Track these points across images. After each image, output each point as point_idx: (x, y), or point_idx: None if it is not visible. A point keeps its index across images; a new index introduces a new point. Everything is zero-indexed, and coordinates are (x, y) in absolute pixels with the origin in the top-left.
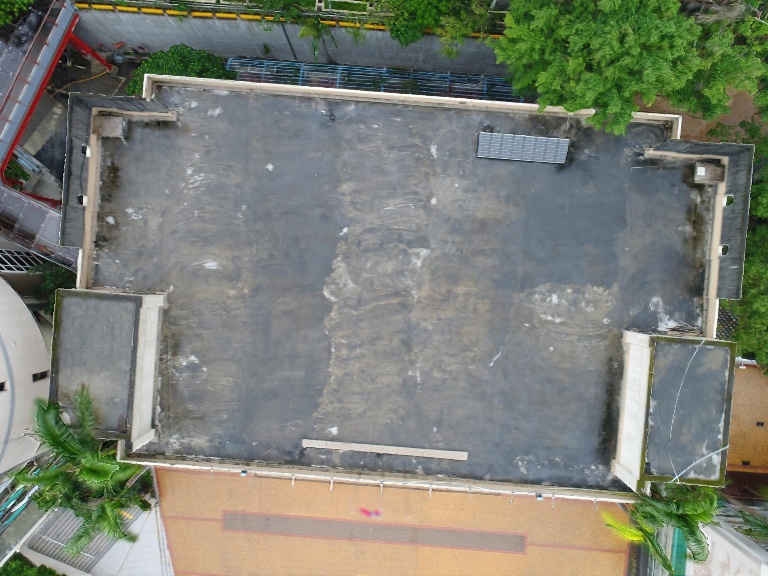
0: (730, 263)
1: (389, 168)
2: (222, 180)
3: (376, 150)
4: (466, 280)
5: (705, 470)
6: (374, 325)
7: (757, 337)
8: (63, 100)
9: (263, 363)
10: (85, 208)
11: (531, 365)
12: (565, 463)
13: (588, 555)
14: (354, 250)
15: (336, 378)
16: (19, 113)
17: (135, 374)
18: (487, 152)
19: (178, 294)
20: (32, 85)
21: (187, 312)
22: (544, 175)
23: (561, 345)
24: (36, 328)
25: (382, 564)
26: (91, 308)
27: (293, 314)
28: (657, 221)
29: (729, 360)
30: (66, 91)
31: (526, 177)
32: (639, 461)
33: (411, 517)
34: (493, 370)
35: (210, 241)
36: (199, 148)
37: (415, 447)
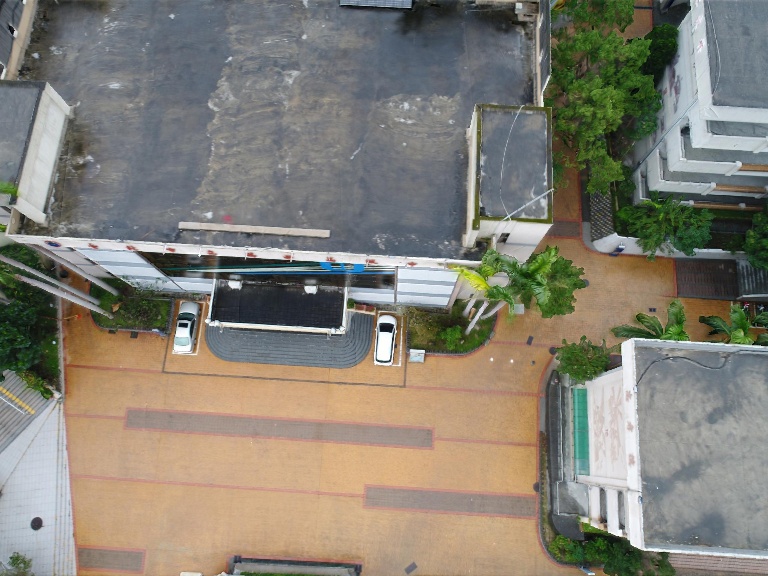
0: (544, 58)
1: (269, 15)
2: (132, 26)
3: (259, 3)
4: (330, 93)
5: (535, 212)
6: (250, 129)
7: (596, 154)
8: None
9: (150, 160)
10: (14, 39)
11: (387, 158)
12: (420, 239)
13: (498, 449)
14: (236, 73)
15: (214, 171)
16: None
17: (30, 141)
18: (347, 0)
19: (83, 108)
20: None
21: (89, 122)
22: (395, 18)
23: (413, 141)
24: None
25: (285, 463)
26: (1, 93)
27: (180, 121)
28: (490, 48)
29: (546, 121)
30: None
31: (380, 19)
32: (473, 204)
33: (316, 412)
34: (353, 162)
35: (116, 68)
36: (116, 5)
37: (282, 227)
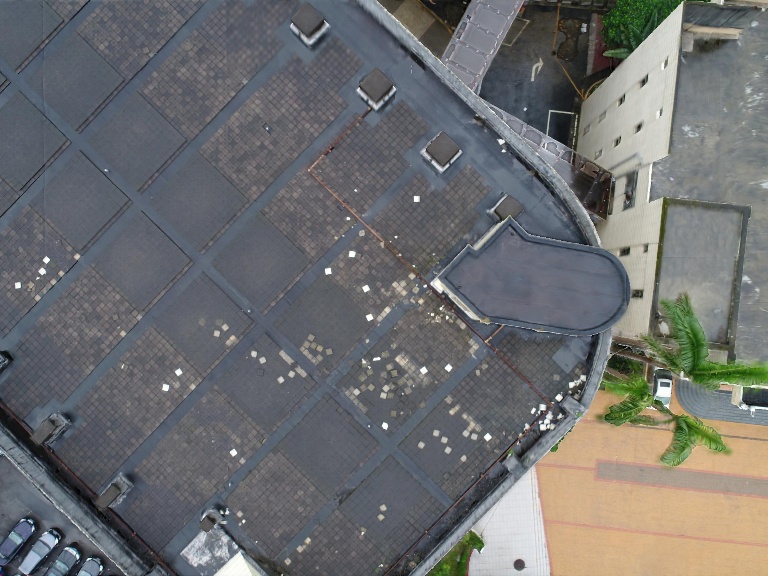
0: None
1: None
2: None
3: None
4: None
5: None
6: None
7: None
8: None
9: None
10: None
11: None
12: None
13: None
14: None
15: None
16: None
17: (741, 285)
18: None
19: None
20: None
21: None
22: None
23: None
24: None
25: (756, 519)
26: (696, 217)
27: None
28: None
29: None
30: None
31: None
32: None
33: None
34: None
35: (767, 161)
36: (759, 67)
37: None
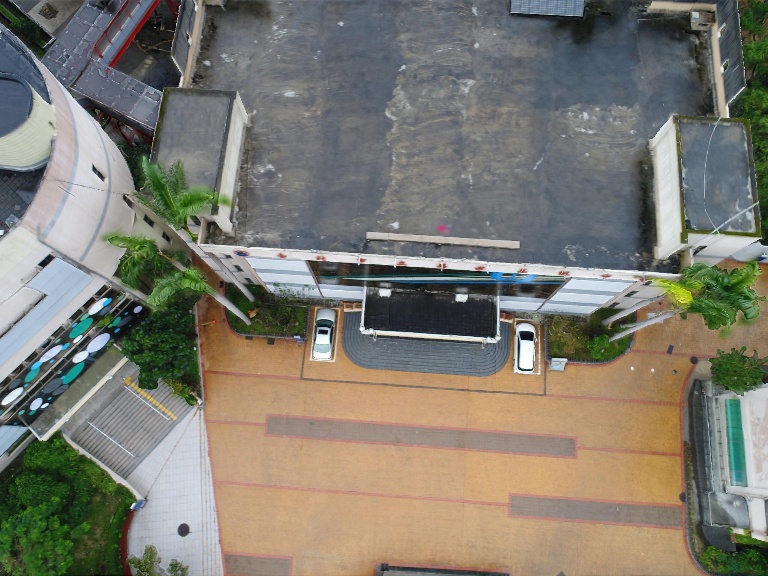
0: (732, 69)
1: (439, 23)
2: (301, 33)
3: (428, 11)
4: (508, 102)
5: (741, 225)
6: (430, 138)
7: None
8: (154, 54)
9: (332, 170)
10: (189, 46)
11: (570, 168)
12: (611, 251)
13: (642, 459)
14: (411, 81)
15: (397, 181)
16: (129, 27)
17: (226, 150)
18: (518, 8)
19: (260, 116)
20: (142, 7)
21: (267, 130)
22: (566, 26)
23: (595, 151)
24: (127, 169)
25: (429, 471)
26: (192, 102)
27: (359, 130)
28: (665, 57)
29: (745, 133)
30: (157, 48)
31: (552, 28)
32: (679, 216)
33: (457, 420)
34: (537, 173)
35: (290, 76)
36: (284, 12)
37: (470, 238)
